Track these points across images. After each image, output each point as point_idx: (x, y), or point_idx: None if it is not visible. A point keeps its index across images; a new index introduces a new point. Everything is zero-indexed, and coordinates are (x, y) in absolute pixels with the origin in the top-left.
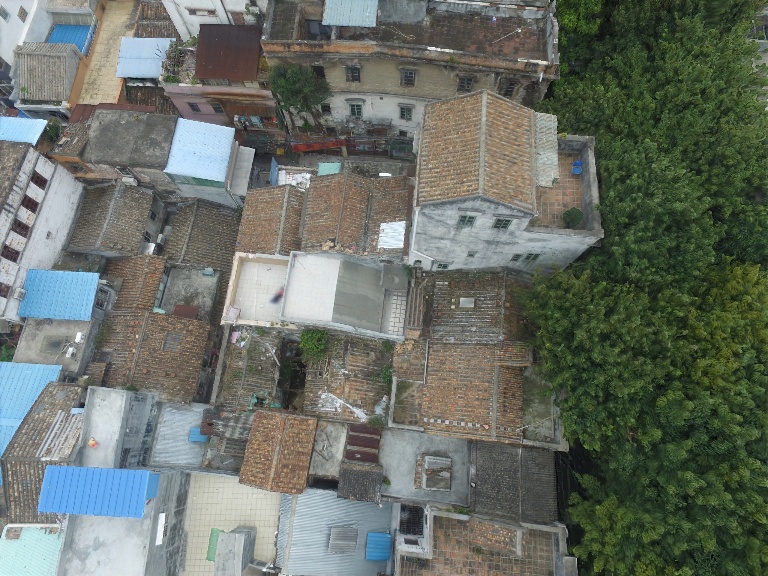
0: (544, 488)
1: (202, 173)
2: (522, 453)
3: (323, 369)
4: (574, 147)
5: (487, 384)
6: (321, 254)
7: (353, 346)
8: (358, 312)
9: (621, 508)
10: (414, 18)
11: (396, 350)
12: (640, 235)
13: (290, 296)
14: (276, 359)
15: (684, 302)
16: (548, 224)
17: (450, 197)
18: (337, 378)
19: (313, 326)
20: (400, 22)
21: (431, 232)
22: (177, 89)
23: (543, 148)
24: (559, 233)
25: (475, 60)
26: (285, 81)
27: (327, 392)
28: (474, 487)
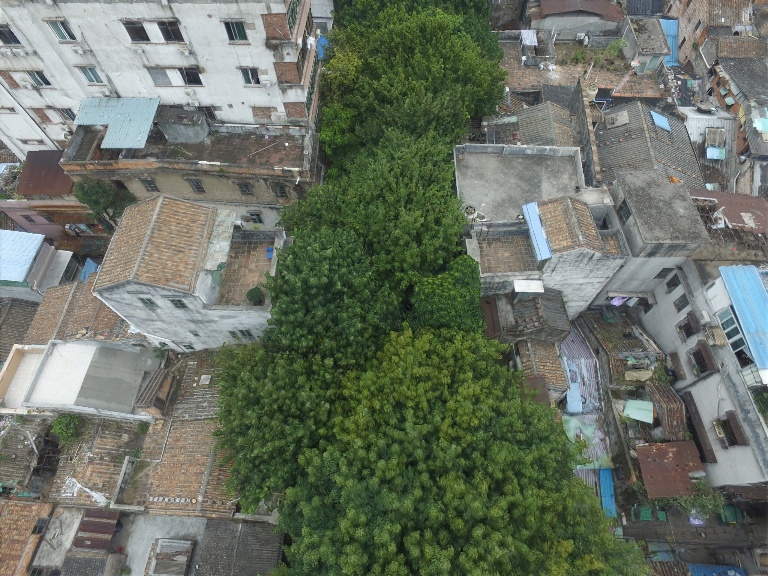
0: (264, 565)
1: (2, 275)
2: (242, 528)
3: (74, 454)
4: (272, 236)
5: (205, 458)
6: (78, 342)
7: (105, 429)
8: (108, 395)
9: (273, 574)
10: (196, 139)
11: (149, 431)
12: (285, 307)
13: (40, 382)
14: (34, 447)
15: (327, 364)
16: (241, 302)
17: (114, 282)
18: (82, 462)
19: (60, 410)
20: (186, 143)
21: (136, 315)
22: (7, 204)
23: (217, 238)
24: (233, 309)
25: (241, 170)
26: (83, 194)
27: (71, 477)
28: (197, 569)
